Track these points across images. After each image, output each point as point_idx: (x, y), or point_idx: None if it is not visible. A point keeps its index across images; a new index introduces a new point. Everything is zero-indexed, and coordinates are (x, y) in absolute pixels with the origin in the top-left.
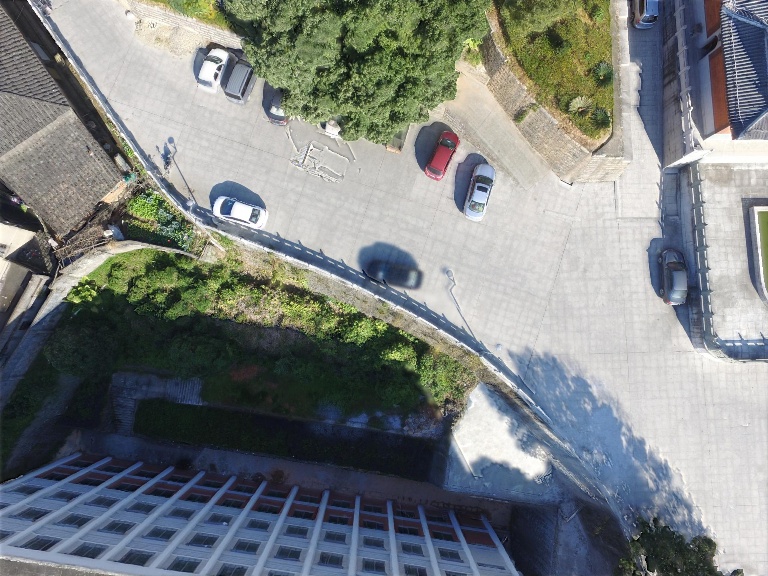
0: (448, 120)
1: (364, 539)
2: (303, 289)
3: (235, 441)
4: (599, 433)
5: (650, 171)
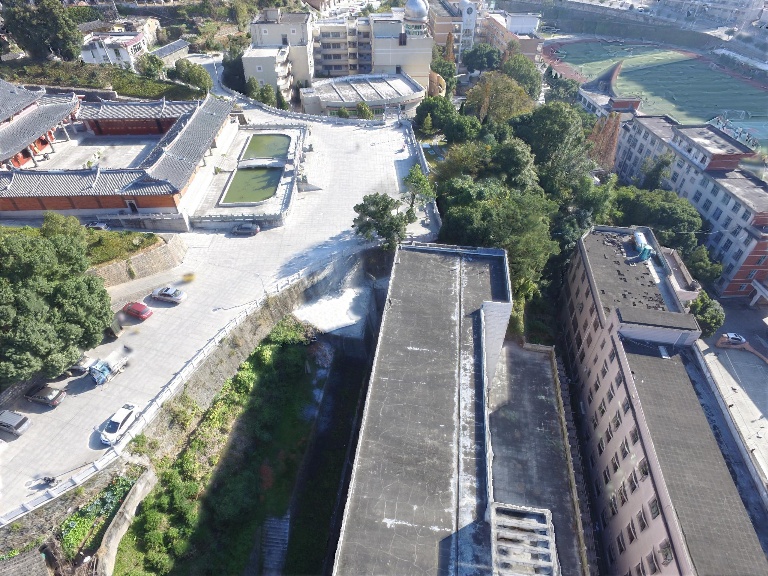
0: (116, 309)
1: None
2: (204, 414)
3: (329, 494)
4: (320, 255)
5: (188, 236)
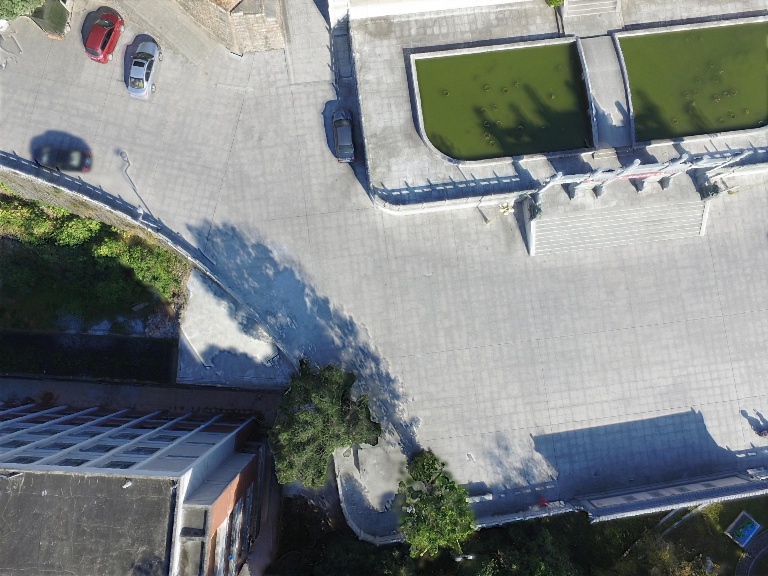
0: (110, 2)
1: (81, 433)
2: (13, 197)
3: None
4: (282, 296)
5: (318, 34)
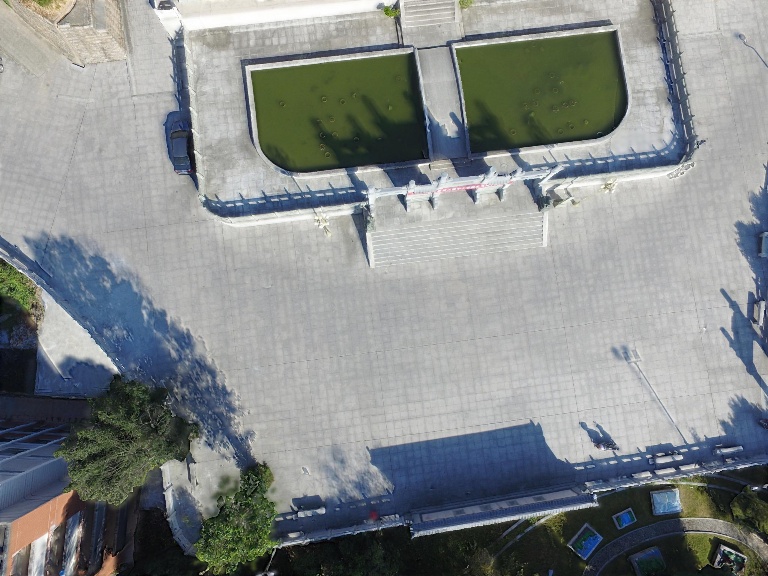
0: None
1: None
2: None
3: None
4: (119, 309)
5: (161, 45)
